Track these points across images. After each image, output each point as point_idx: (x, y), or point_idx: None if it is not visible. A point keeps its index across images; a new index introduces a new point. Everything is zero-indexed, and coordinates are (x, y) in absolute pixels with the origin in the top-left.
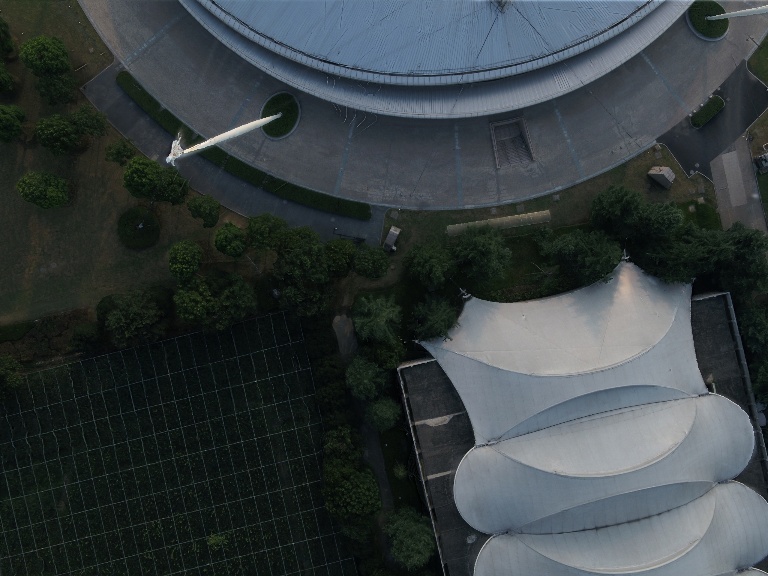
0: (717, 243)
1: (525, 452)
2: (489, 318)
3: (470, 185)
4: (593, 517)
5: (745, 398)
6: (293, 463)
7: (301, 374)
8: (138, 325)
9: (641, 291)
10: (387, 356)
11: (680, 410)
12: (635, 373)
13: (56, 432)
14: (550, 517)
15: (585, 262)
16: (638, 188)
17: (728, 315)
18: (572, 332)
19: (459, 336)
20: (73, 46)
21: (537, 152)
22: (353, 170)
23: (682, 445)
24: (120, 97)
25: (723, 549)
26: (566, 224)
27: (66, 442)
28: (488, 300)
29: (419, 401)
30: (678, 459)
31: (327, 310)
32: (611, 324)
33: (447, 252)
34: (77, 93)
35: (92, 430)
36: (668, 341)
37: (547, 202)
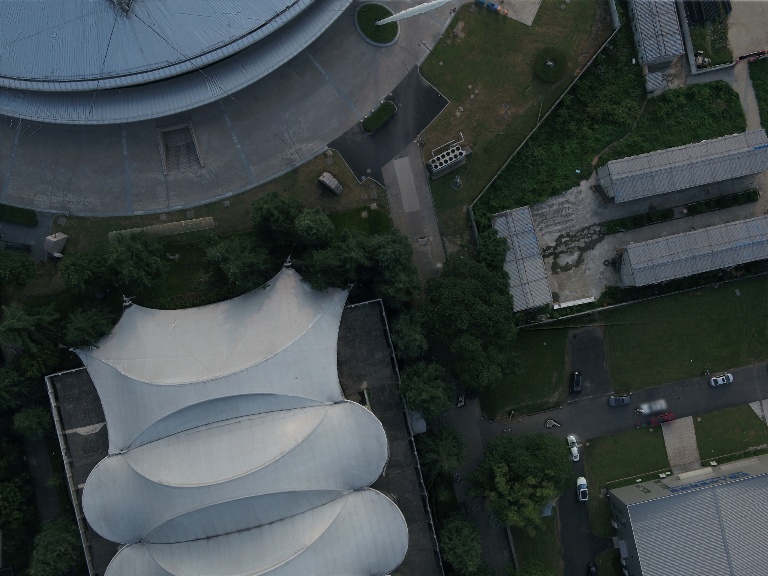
0: (351, 250)
1: (144, 461)
2: (141, 326)
3: (139, 191)
4: (202, 527)
5: (399, 405)
6: None
7: None
8: None
9: (292, 298)
10: (28, 365)
11: (304, 418)
12: (250, 381)
13: None
14: (161, 527)
15: None
16: (310, 194)
17: (383, 322)
18: (210, 340)
19: (110, 344)
20: None
21: (206, 158)
22: (20, 176)
23: (290, 454)
24: None
25: (342, 557)
26: (237, 230)
27: None
28: (157, 307)
29: (70, 409)
30: (283, 468)
31: None
32: (249, 332)
33: (99, 259)
34: None
35: None
36: (297, 349)
37: (217, 208)
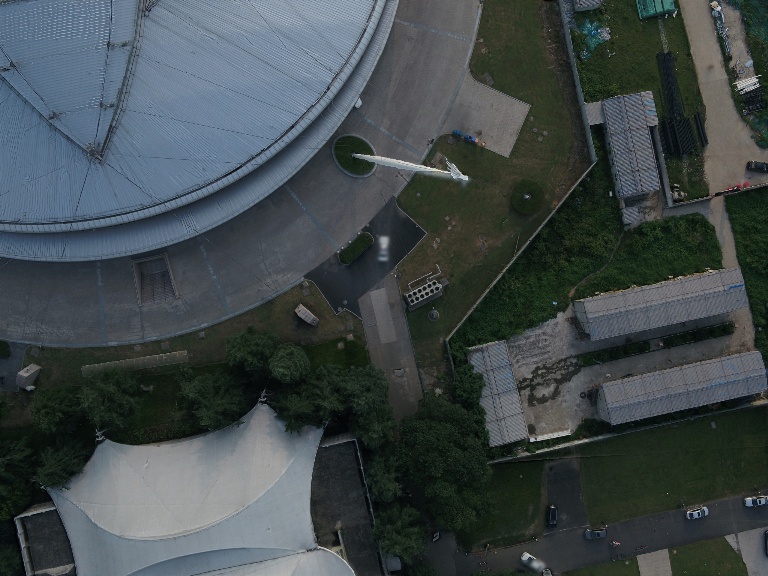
0: None
1: None
2: (113, 465)
3: (113, 322)
4: None
5: (374, 545)
6: None
7: None
8: None
9: (266, 438)
10: None
11: (275, 570)
12: (221, 537)
13: None
14: None
15: None
16: (285, 325)
17: (357, 461)
18: (182, 485)
19: (81, 484)
20: None
21: (182, 289)
22: None
23: None
24: None
25: None
26: (212, 361)
27: None
28: (131, 439)
29: (40, 550)
30: None
31: None
32: (221, 477)
33: (71, 397)
34: None
35: None
36: (269, 498)
37: (192, 339)
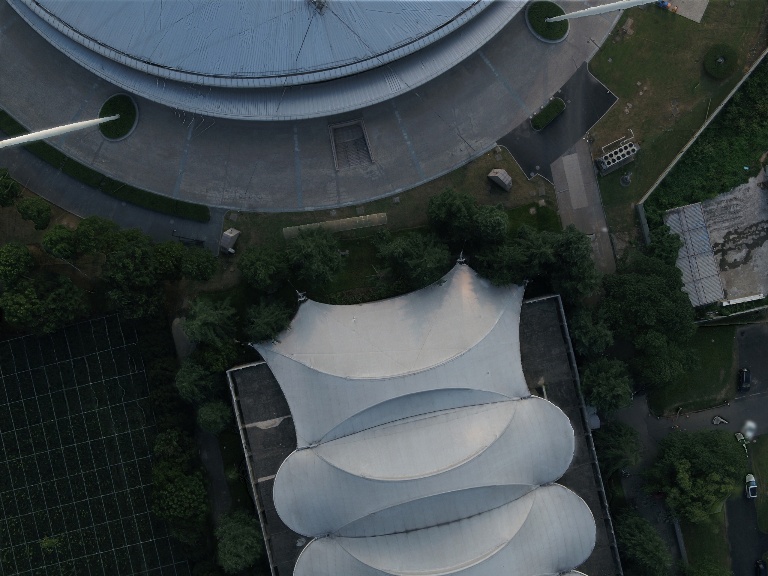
0: (539, 246)
1: (339, 455)
2: (320, 321)
3: (310, 187)
4: (402, 520)
5: (576, 401)
6: (127, 466)
7: (136, 376)
8: None
9: (471, 294)
10: (213, 359)
11: (496, 413)
12: (448, 376)
13: None
14: (360, 520)
15: None
16: (478, 190)
17: (560, 318)
18: (396, 335)
19: (290, 339)
20: None
21: (377, 154)
22: (192, 172)
23: (491, 448)
24: None
25: (536, 552)
26: (406, 226)
27: None
28: (328, 302)
29: (250, 404)
30: (485, 462)
31: (165, 312)
32: (435, 327)
33: (278, 254)
34: None
35: None
36: (487, 344)
37: (387, 204)
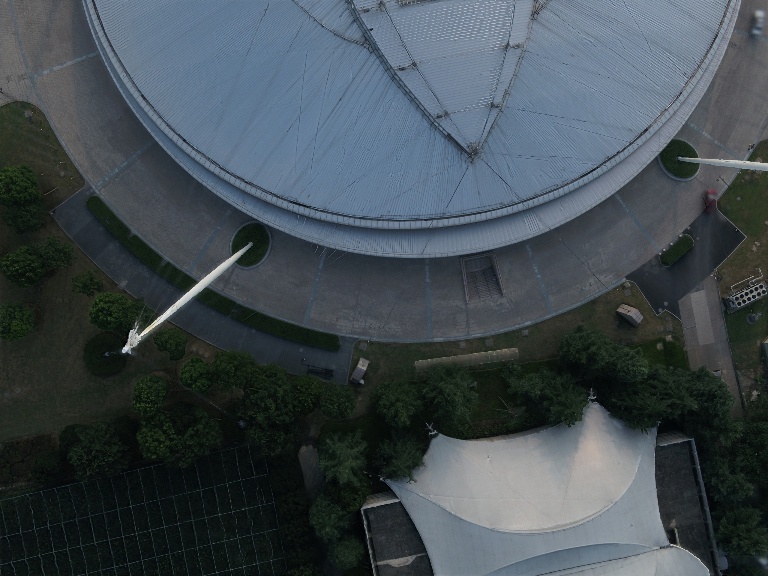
0: (681, 396)
1: None
2: (454, 459)
3: (440, 318)
4: None
5: (707, 544)
6: None
7: (265, 507)
8: (100, 462)
9: (606, 436)
10: (350, 499)
11: (640, 566)
12: (596, 532)
13: (14, 563)
14: None
15: (550, 409)
16: (607, 325)
17: (692, 460)
18: (536, 480)
19: (424, 477)
20: (44, 169)
21: (507, 287)
22: (323, 301)
23: None
24: (90, 222)
25: None
26: (534, 359)
27: (25, 572)
28: (455, 434)
29: (382, 541)
30: None
31: None
32: (575, 473)
33: (414, 391)
34: (46, 217)
35: (51, 561)
36: (630, 495)
37: (516, 337)
